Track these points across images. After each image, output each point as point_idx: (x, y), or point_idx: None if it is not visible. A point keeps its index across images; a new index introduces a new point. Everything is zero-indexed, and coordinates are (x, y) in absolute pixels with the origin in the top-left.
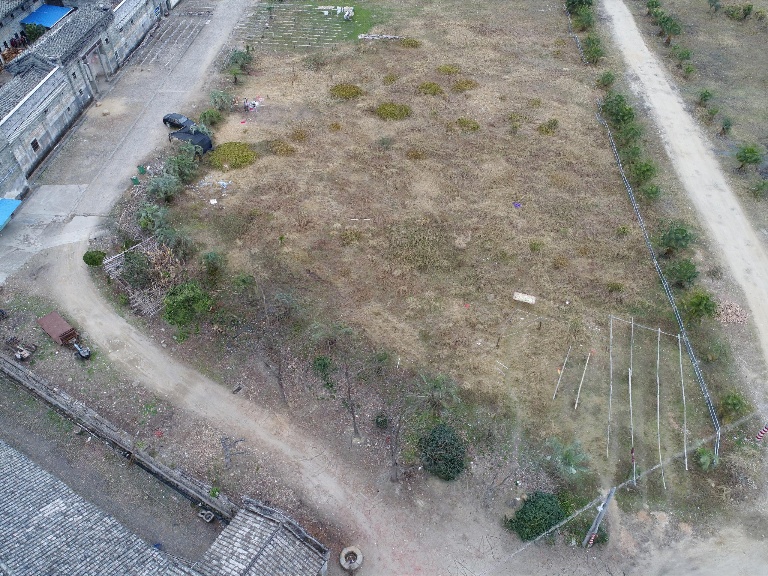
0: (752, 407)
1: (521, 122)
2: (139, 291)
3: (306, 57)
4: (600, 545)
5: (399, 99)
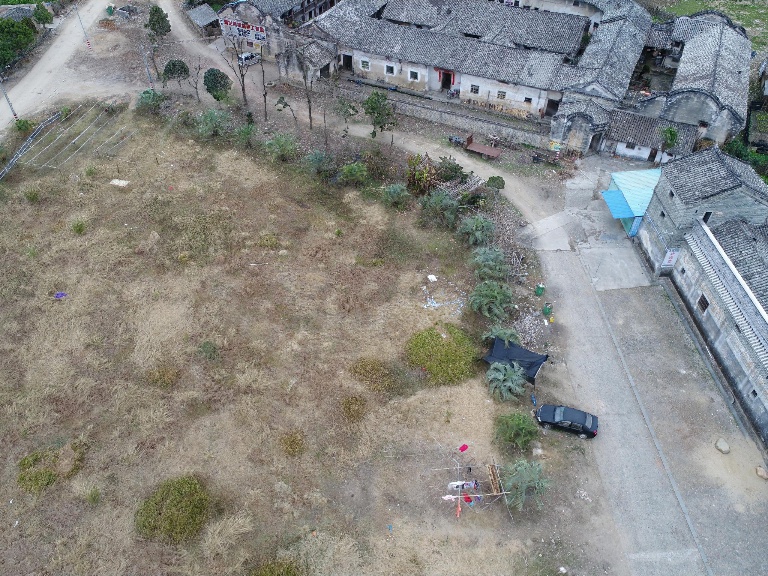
0: (5, 140)
1: None
2: None
3: None
4: None
5: (151, 573)
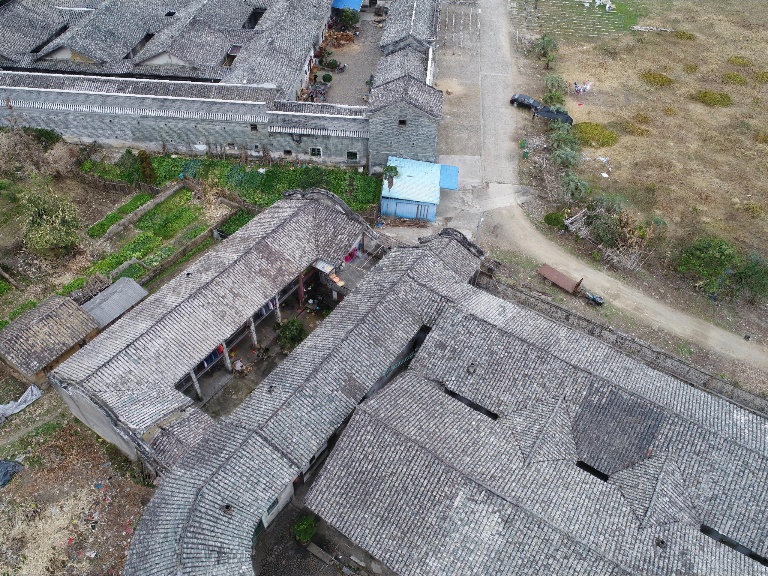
0: None
1: None
2: (610, 249)
3: (595, 46)
4: None
5: (711, 88)
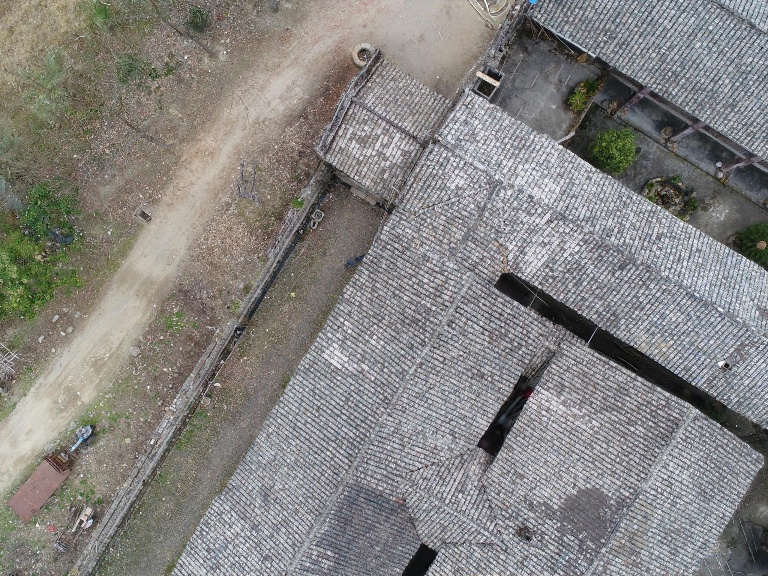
0: None
1: None
2: None
3: None
4: None
5: None
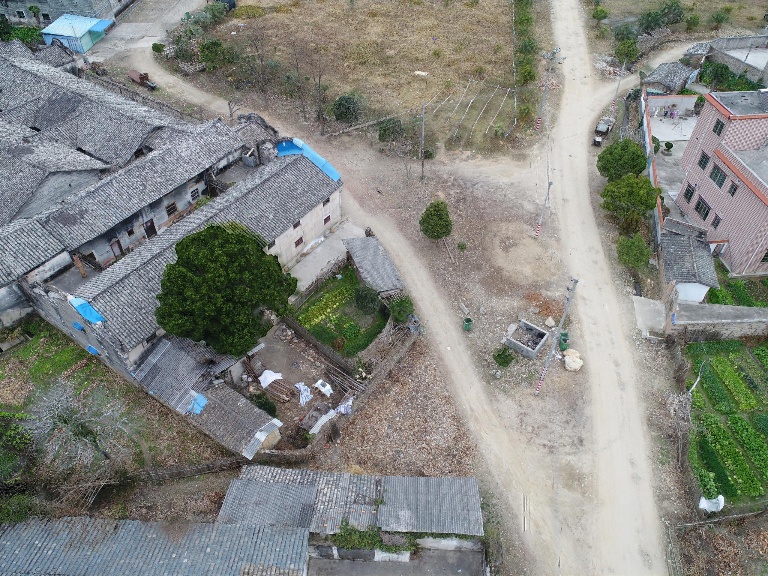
0: (542, 119)
1: (454, 1)
2: (185, 63)
3: None
4: (429, 159)
5: None
